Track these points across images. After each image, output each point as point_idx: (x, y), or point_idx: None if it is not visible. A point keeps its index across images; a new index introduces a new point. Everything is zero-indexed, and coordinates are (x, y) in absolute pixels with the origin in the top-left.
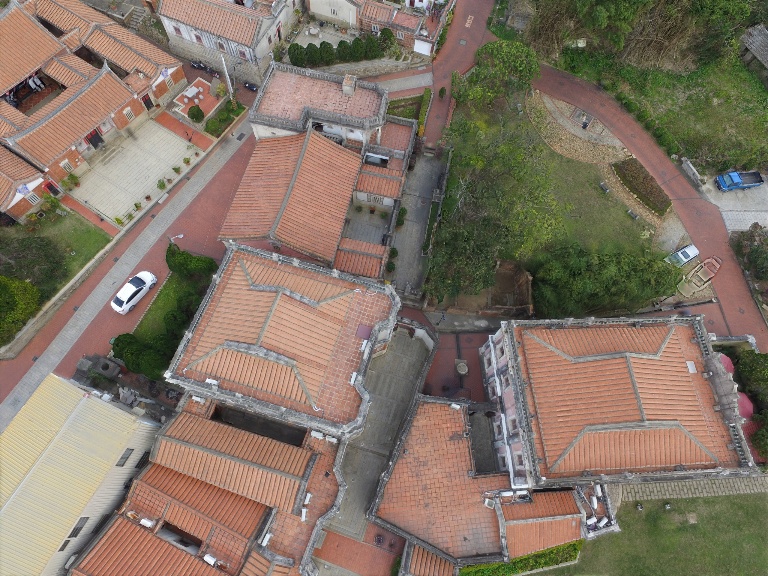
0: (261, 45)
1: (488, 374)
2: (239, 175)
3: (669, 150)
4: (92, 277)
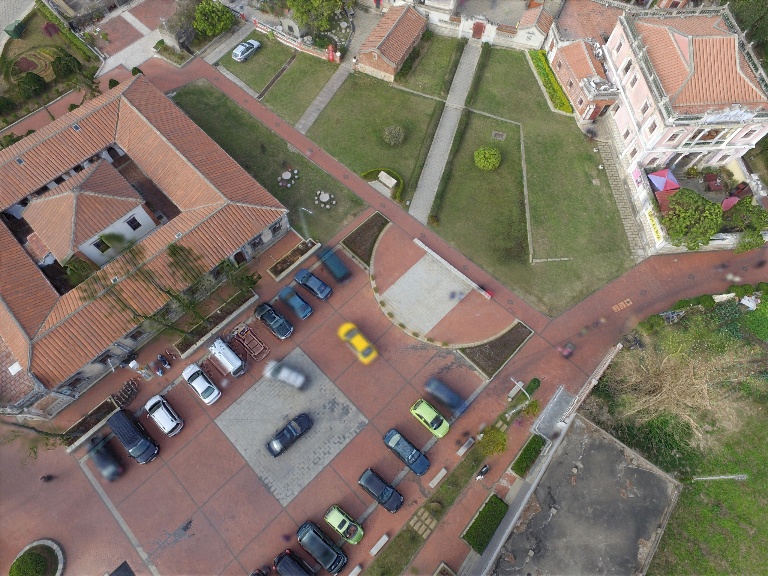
0: None
1: None
2: None
3: None
4: None
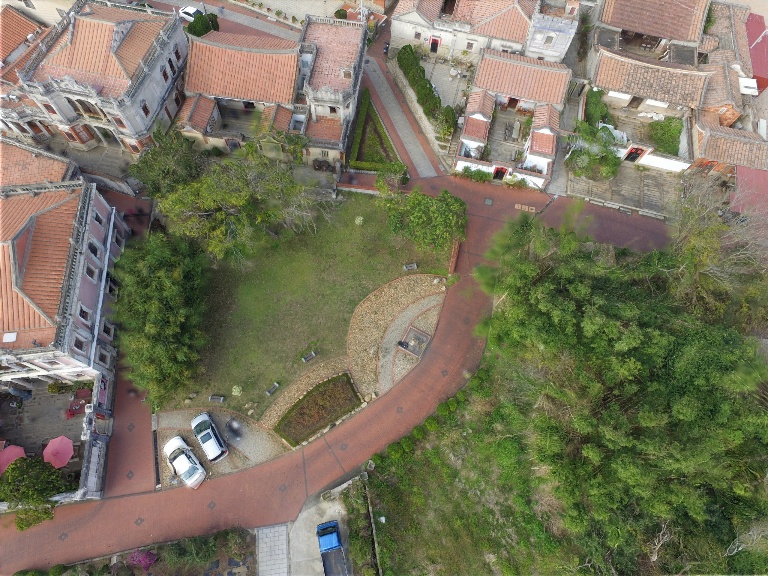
0: (403, 26)
1: None
2: None
3: None
4: (211, 0)
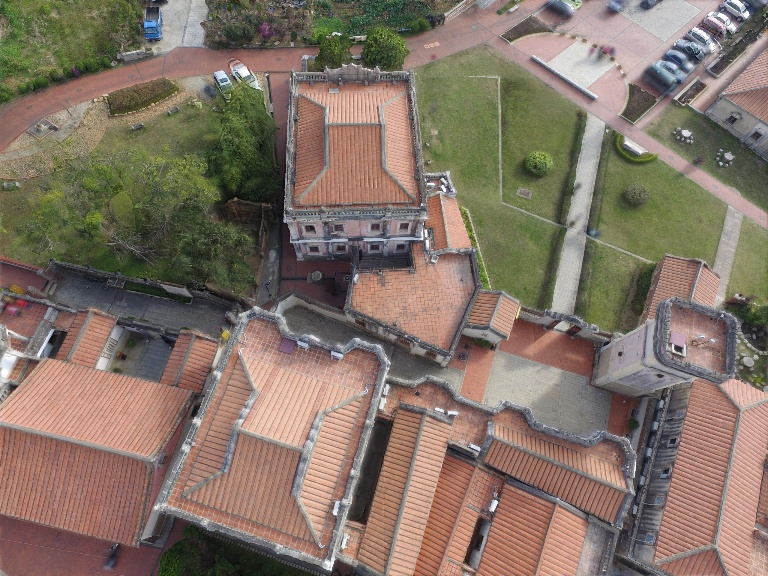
0: None
1: (324, 253)
2: (25, 542)
3: (105, 65)
4: None
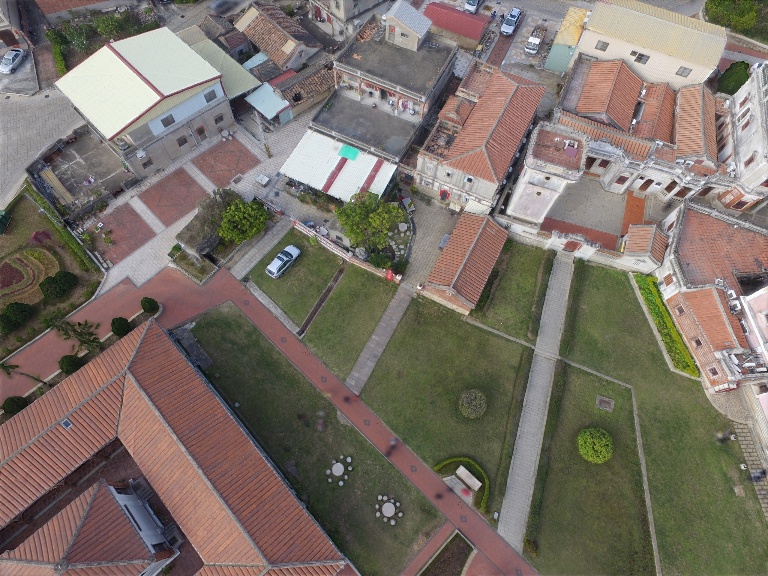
0: None
1: None
2: None
3: None
4: (766, 55)
